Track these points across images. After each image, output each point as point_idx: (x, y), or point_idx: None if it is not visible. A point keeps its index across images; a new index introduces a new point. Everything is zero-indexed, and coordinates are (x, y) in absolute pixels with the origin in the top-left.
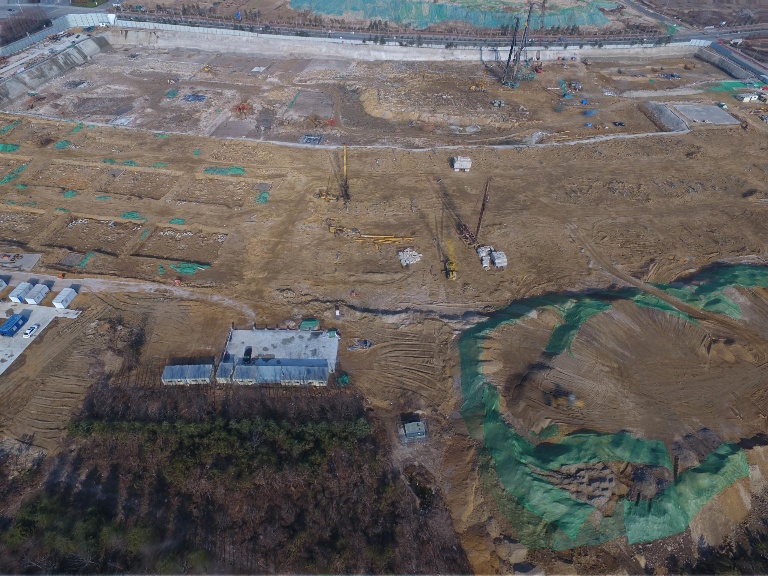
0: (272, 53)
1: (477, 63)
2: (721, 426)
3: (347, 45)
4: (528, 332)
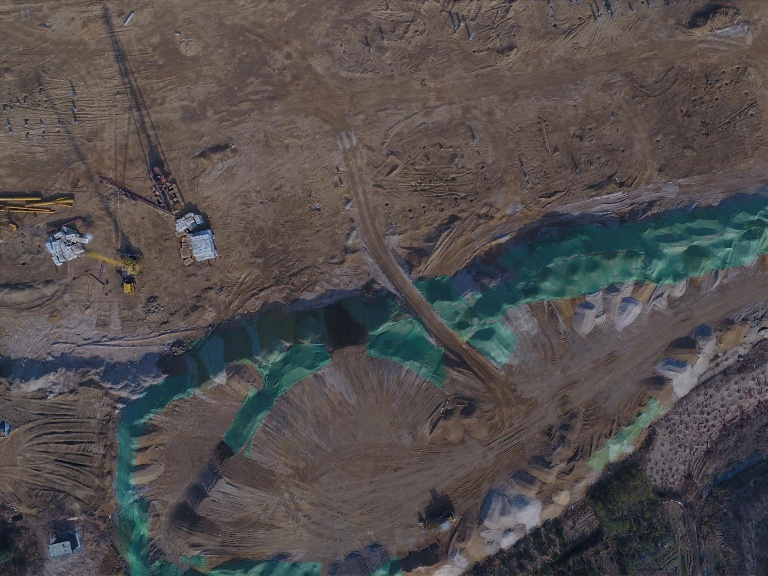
0: None
1: None
2: (395, 539)
3: None
4: (208, 410)
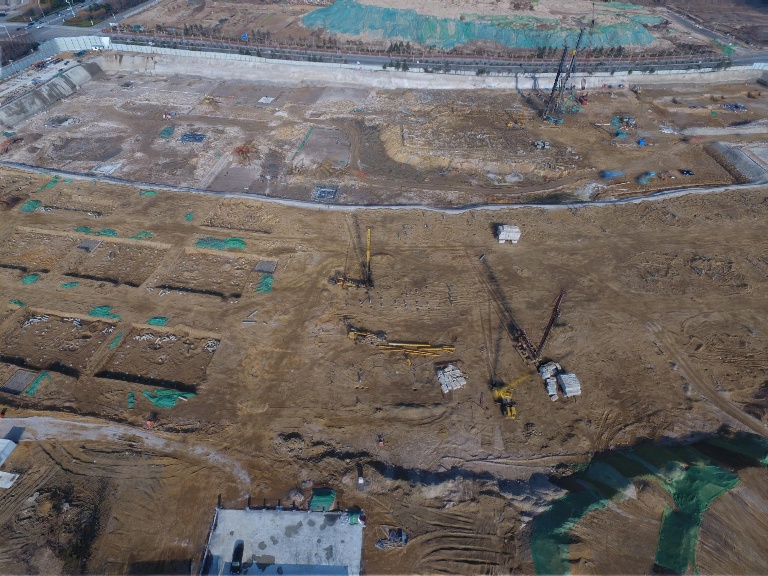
0: (281, 80)
1: (512, 92)
2: None
3: (365, 71)
4: (628, 525)
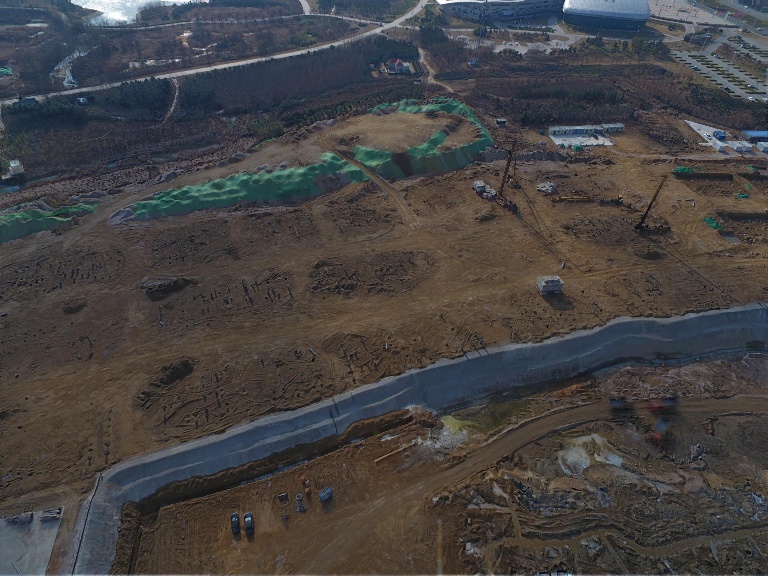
0: None
1: None
2: None
3: None
4: (457, 142)
